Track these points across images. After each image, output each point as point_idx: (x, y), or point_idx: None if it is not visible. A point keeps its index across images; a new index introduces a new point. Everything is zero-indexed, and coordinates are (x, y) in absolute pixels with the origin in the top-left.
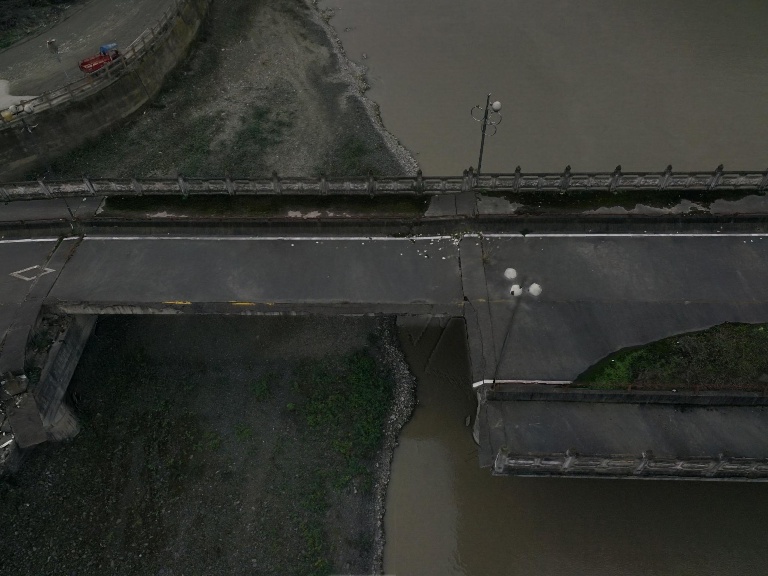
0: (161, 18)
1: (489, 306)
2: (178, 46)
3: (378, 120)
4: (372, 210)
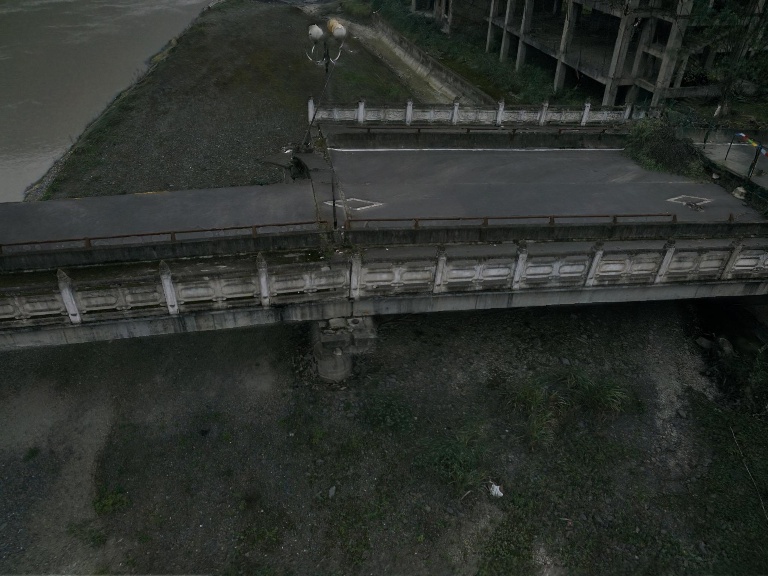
0: None
1: None
2: None
3: None
4: None
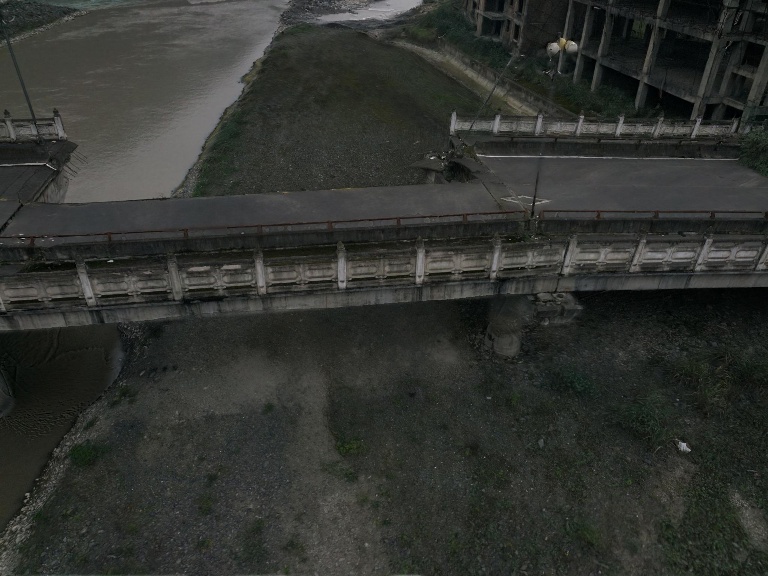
0: None
1: None
2: None
3: None
4: None
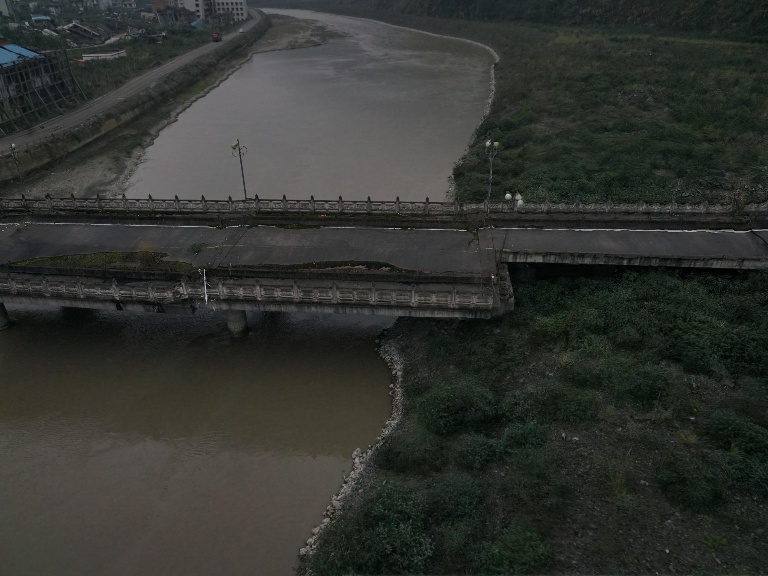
0: (7, 150)
1: None
2: (19, 168)
3: None
4: None
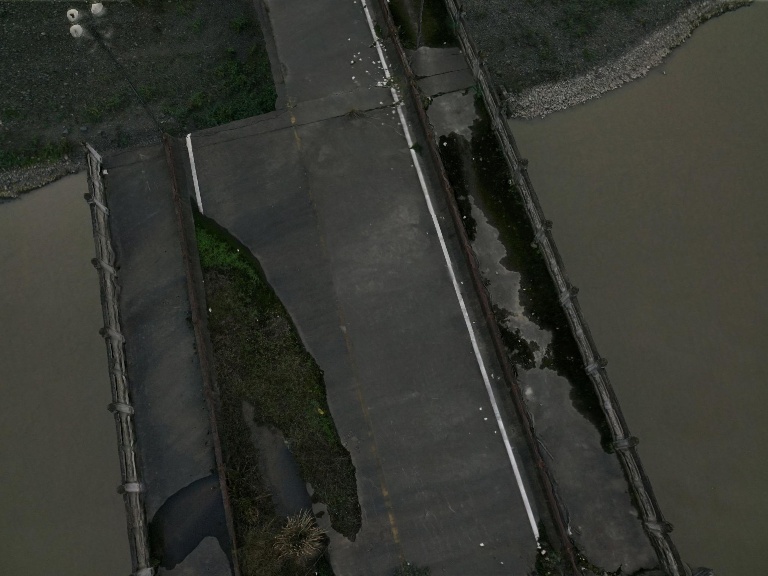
0: None
1: (286, 127)
2: None
3: (712, 11)
4: None
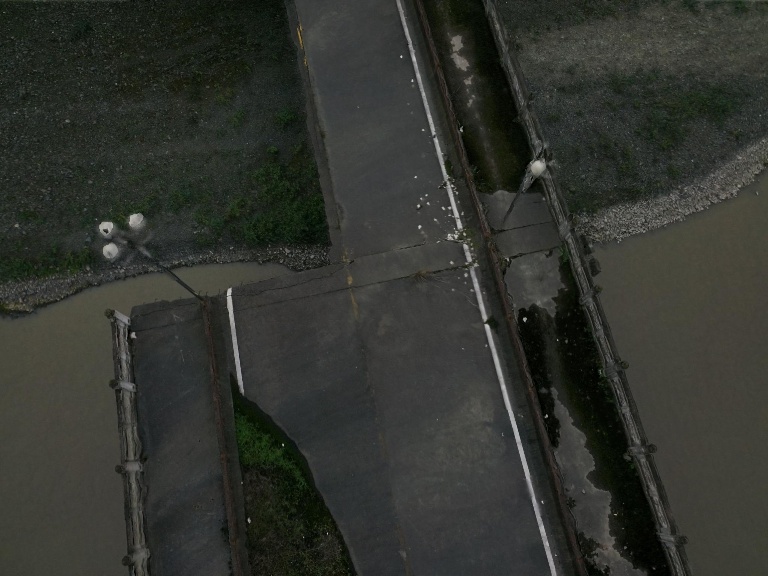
0: None
1: (342, 289)
2: None
3: None
4: (489, 126)
